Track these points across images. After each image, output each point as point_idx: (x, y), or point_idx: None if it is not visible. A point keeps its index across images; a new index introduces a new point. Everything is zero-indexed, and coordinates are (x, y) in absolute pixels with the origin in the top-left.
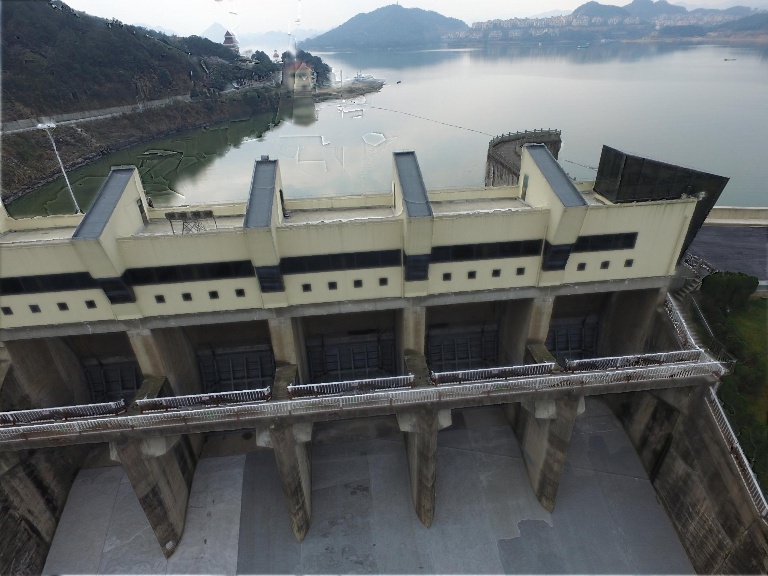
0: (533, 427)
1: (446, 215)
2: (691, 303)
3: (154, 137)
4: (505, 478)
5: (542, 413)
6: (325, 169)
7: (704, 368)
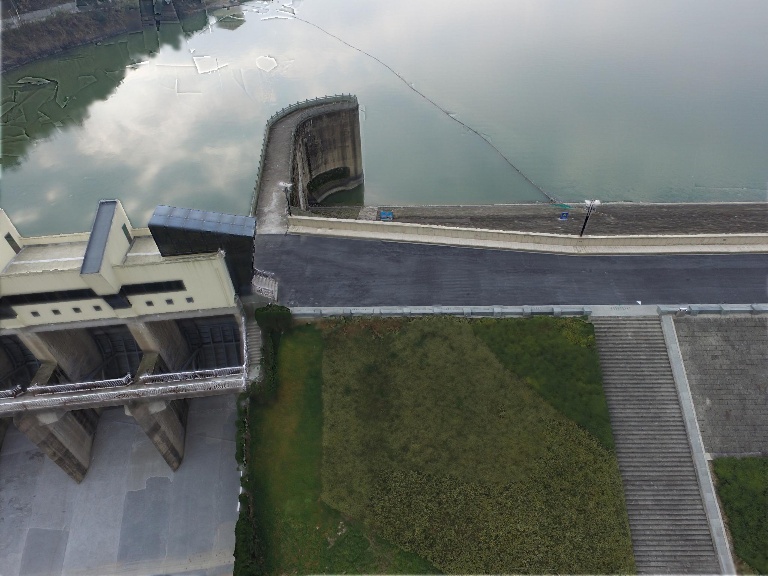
0: None
1: (2, 275)
2: None
3: (36, 58)
4: (151, 446)
5: (127, 412)
6: (206, 101)
7: (235, 383)
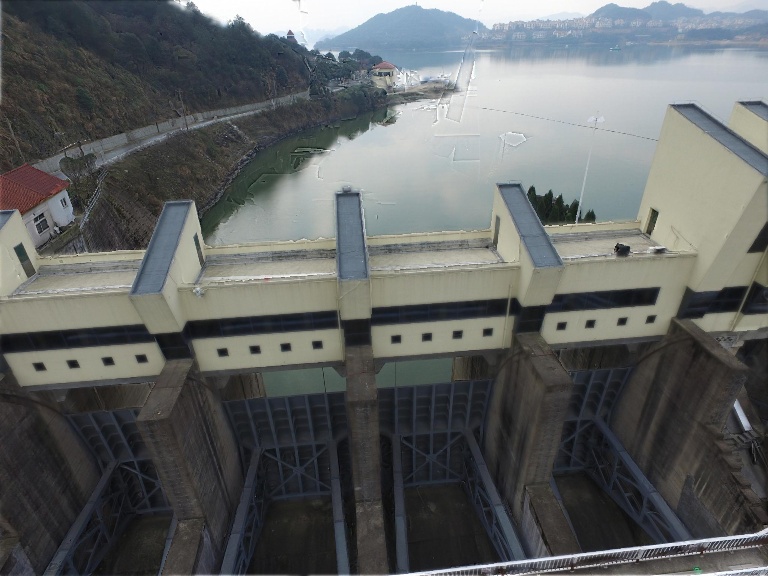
0: None
1: None
2: None
3: (287, 135)
4: None
5: None
6: None
7: None
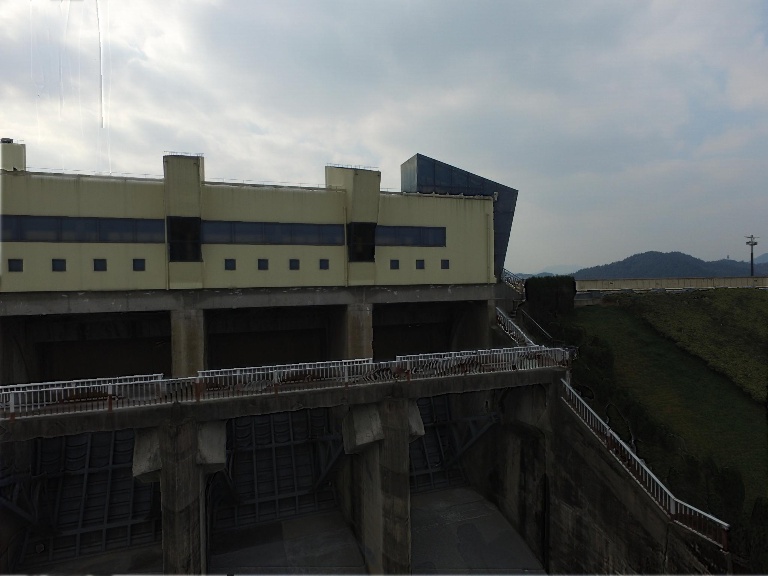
0: (367, 490)
1: (223, 182)
2: (522, 316)
3: None
4: None
5: (364, 435)
6: None
7: (548, 357)
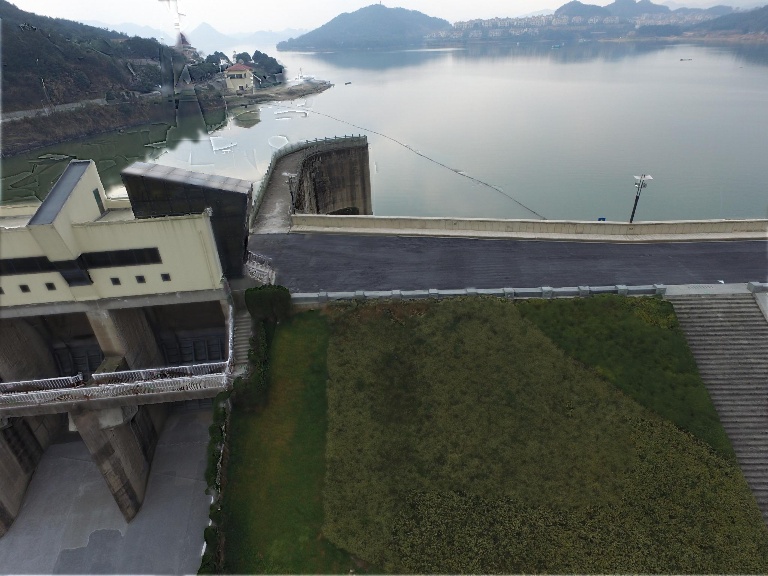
0: None
1: None
2: None
3: (60, 141)
4: (103, 488)
5: (71, 426)
6: None
7: (214, 381)
